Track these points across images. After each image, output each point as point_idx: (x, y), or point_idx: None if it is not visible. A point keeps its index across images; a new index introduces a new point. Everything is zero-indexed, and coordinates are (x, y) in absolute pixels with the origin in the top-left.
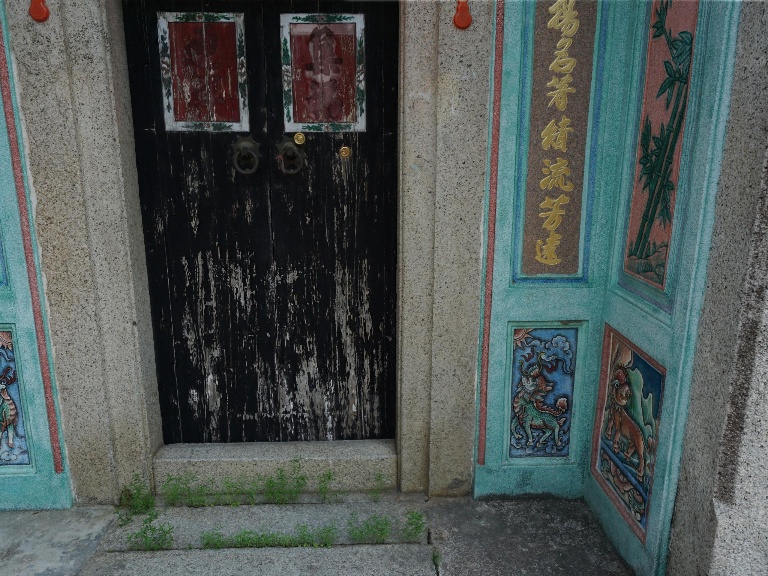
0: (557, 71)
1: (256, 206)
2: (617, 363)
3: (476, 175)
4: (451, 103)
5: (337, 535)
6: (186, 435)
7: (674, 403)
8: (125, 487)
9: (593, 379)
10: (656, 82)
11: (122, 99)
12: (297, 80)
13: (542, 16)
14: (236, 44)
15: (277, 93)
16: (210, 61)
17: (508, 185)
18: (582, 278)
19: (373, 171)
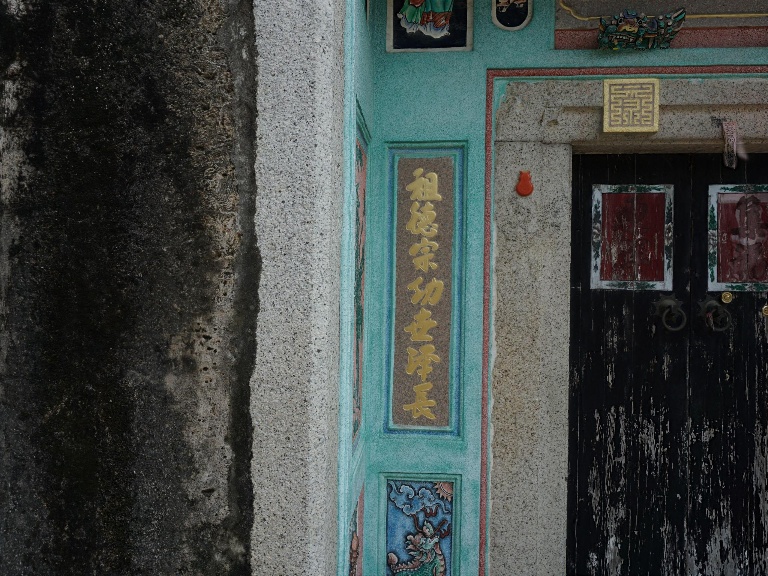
0: None
1: (674, 362)
2: None
3: None
4: None
5: None
6: None
7: None
8: None
9: None
10: None
11: None
12: (722, 243)
13: None
14: (665, 211)
15: (702, 255)
16: (639, 226)
17: None
18: None
19: None
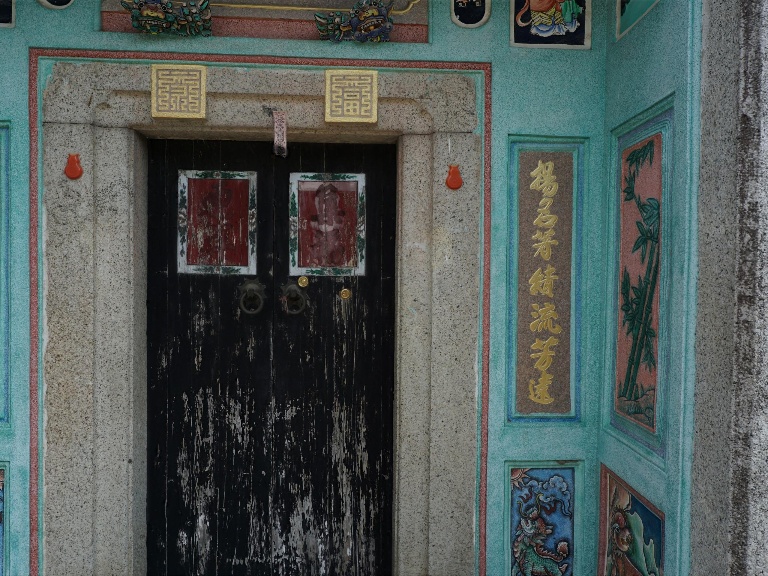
0: (541, 226)
1: (258, 344)
2: (616, 505)
3: (469, 318)
4: (445, 253)
5: None
6: None
7: (676, 551)
8: None
9: (593, 522)
10: (630, 239)
11: (140, 245)
12: (303, 229)
13: (525, 179)
14: (248, 198)
15: (284, 240)
16: (224, 212)
17: (500, 327)
18: (575, 417)
19: (372, 312)
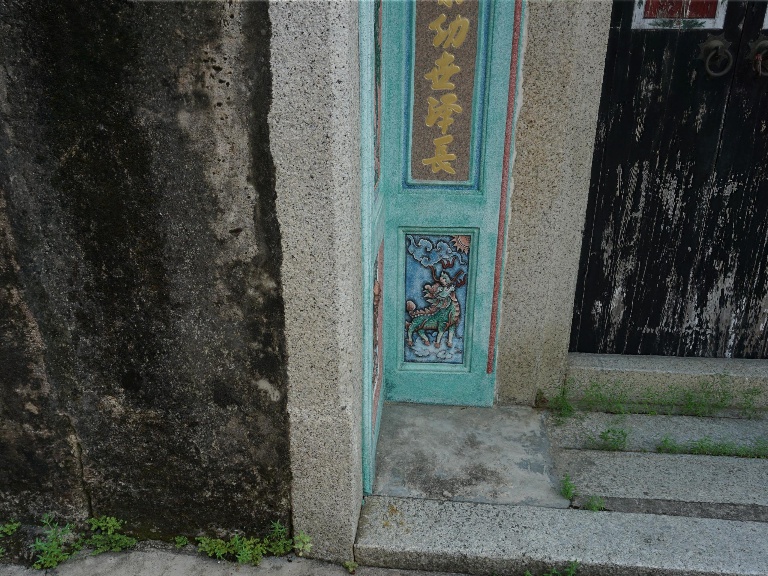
0: None
1: (710, 112)
2: None
3: None
4: None
5: None
6: (582, 345)
7: None
8: (539, 390)
9: None
10: None
11: None
12: None
13: None
14: None
15: None
16: None
17: None
18: None
19: None
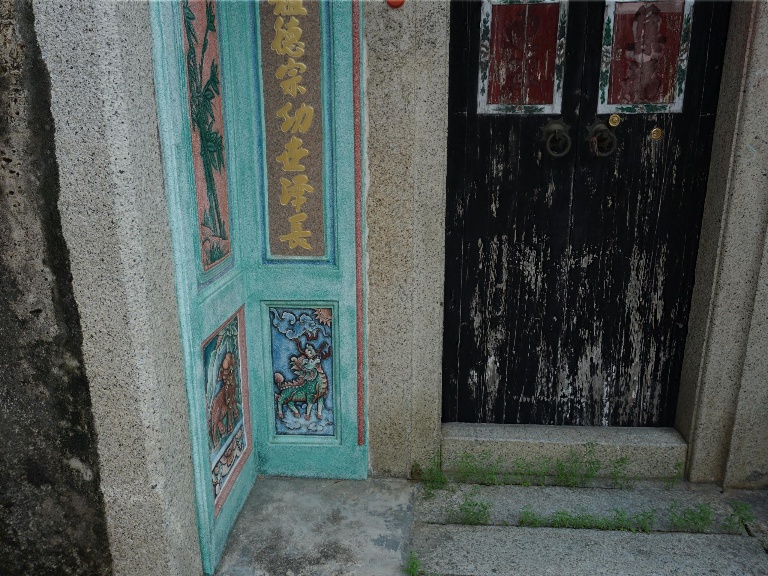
0: None
1: (558, 189)
2: None
3: None
4: None
5: (648, 521)
6: (462, 414)
7: None
8: (415, 462)
9: None
10: None
11: None
12: (616, 60)
13: None
14: (558, 25)
15: (594, 74)
16: (529, 43)
17: None
18: None
19: (684, 153)
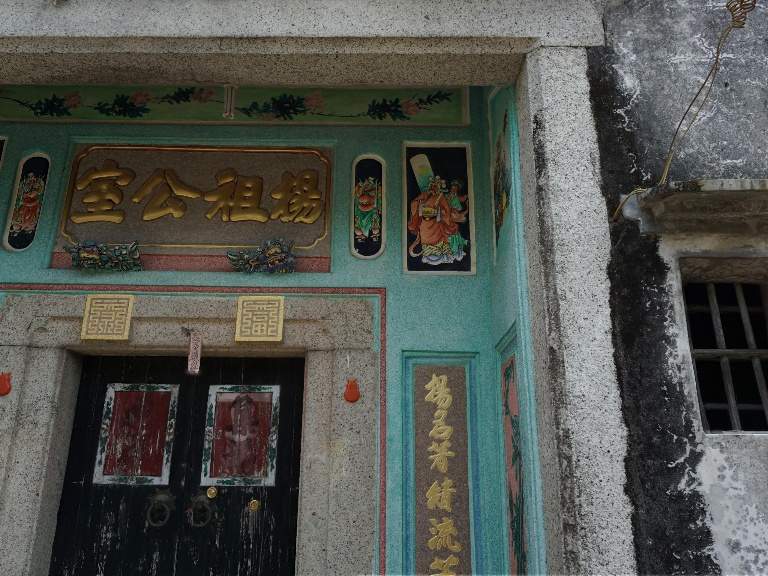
0: (436, 437)
1: (163, 559)
2: None
3: (366, 534)
4: (342, 465)
5: None
6: None
7: None
8: None
9: None
10: (510, 453)
11: (57, 456)
12: (217, 439)
13: (420, 392)
14: (169, 409)
15: (198, 450)
16: (144, 423)
17: (396, 545)
18: None
19: (279, 524)
